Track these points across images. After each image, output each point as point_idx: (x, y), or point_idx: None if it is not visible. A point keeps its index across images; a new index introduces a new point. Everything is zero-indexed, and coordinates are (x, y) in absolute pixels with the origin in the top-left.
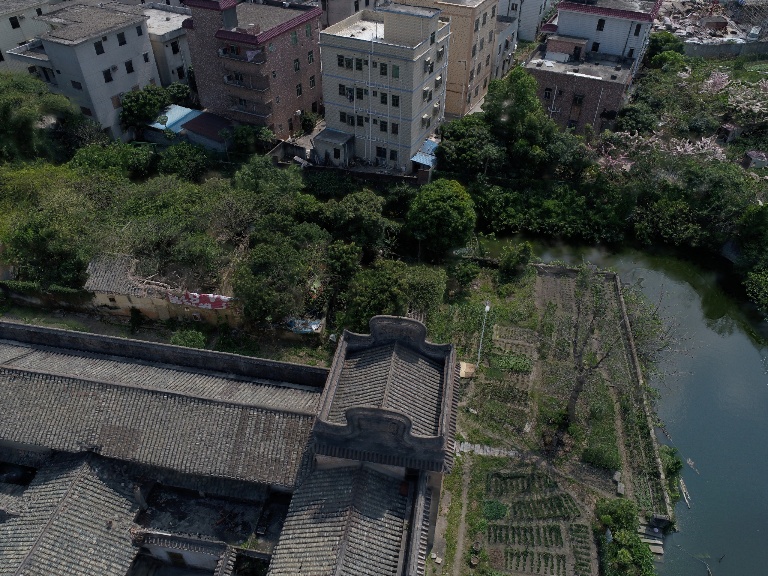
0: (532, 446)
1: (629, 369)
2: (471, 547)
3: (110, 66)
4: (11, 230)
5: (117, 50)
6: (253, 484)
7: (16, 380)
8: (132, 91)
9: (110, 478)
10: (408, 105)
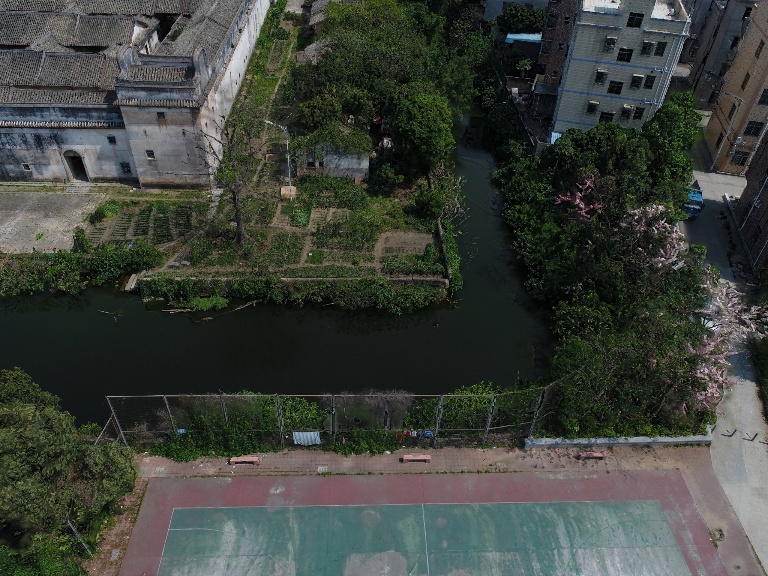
0: (217, 226)
1: None
2: None
3: None
4: None
5: None
6: None
7: None
8: None
9: None
10: None
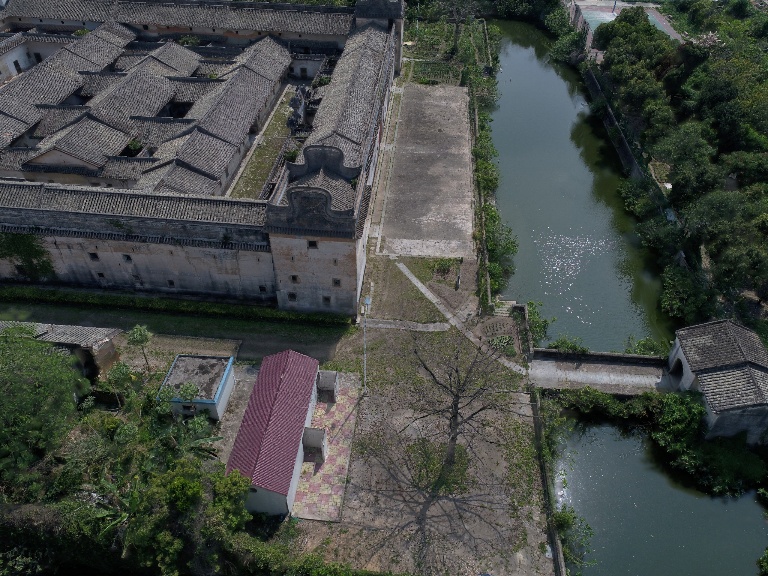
0: (440, 59)
1: (484, 41)
2: (414, 74)
3: None
4: None
5: None
6: (331, 43)
7: (236, 12)
8: None
9: (277, 42)
10: None
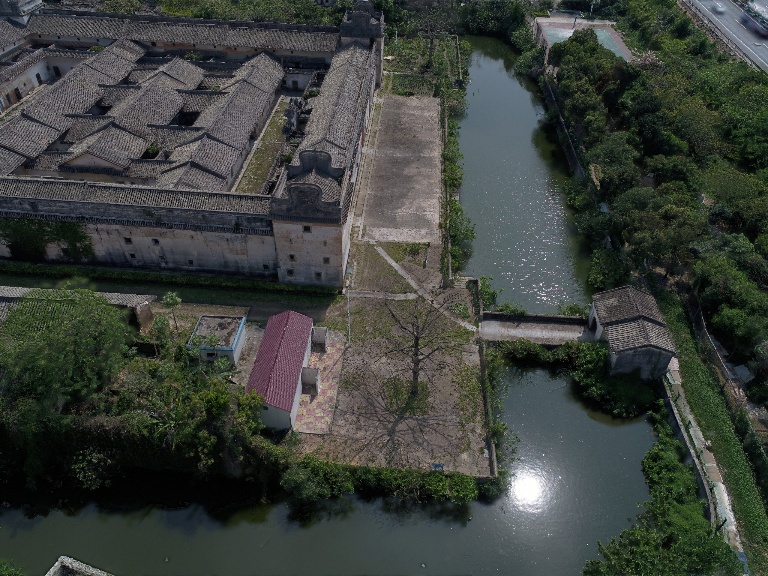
0: (416, 72)
1: None
2: (393, 86)
3: None
4: (192, 13)
5: None
6: (319, 59)
7: (234, 31)
8: None
9: (272, 58)
10: None
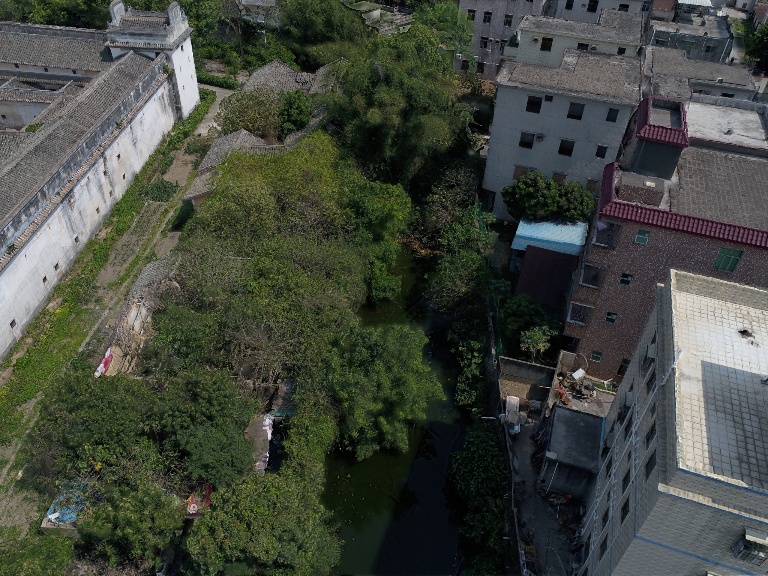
0: None
1: None
2: None
3: (537, 132)
4: None
5: (560, 120)
6: None
7: None
8: (542, 174)
9: None
10: (623, 545)
